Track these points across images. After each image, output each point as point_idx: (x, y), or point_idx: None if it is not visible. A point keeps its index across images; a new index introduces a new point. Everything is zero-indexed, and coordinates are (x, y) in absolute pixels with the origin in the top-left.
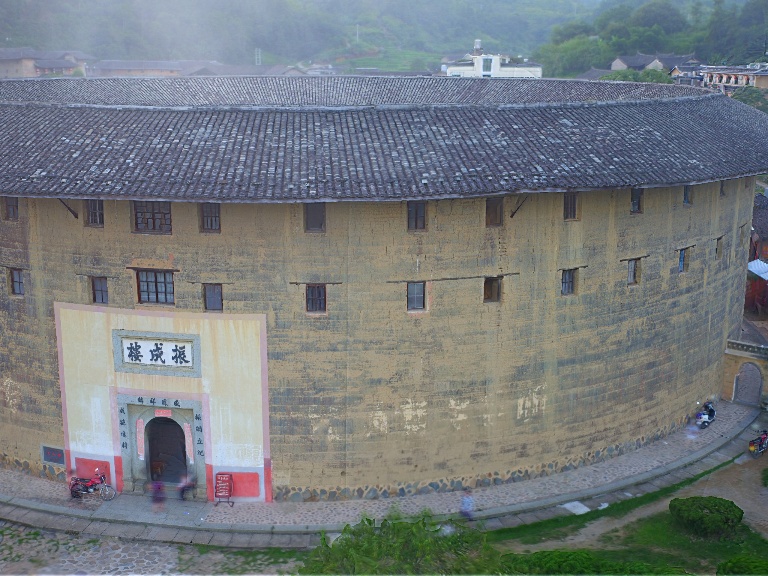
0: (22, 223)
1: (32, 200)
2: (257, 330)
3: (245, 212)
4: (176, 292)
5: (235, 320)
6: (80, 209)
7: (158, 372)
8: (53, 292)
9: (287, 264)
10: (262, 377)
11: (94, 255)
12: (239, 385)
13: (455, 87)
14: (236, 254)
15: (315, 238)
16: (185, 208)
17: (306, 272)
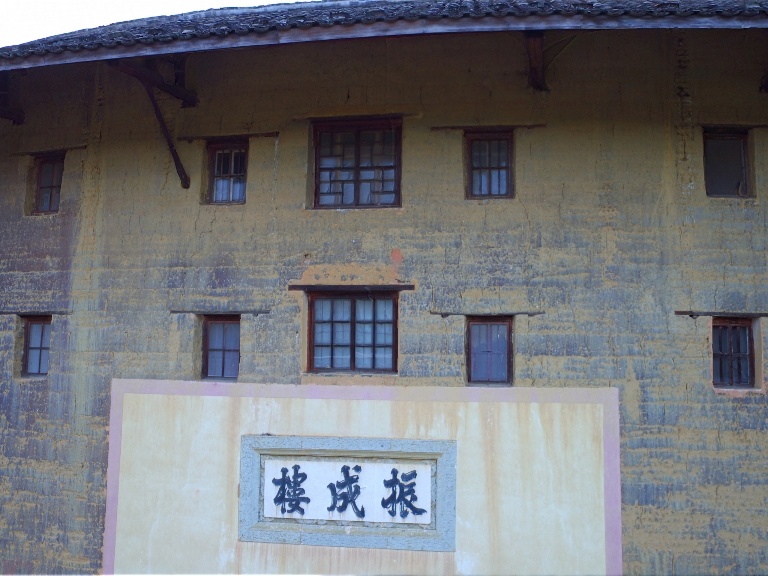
0: (65, 214)
1: (93, 163)
2: (596, 428)
3: (572, 150)
4: (402, 338)
5: (543, 403)
6: (195, 167)
7: (345, 539)
8: (113, 357)
9: (668, 267)
10: (607, 550)
11: (216, 264)
12: (549, 571)
13: None
14: (549, 244)
15: (731, 208)
16: (434, 146)
17: (712, 287)
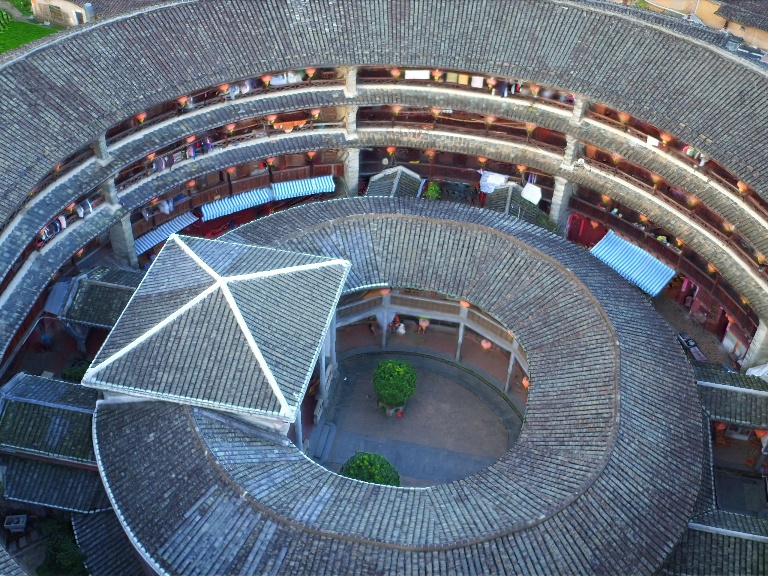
0: None
1: None
2: None
3: None
4: None
5: None
6: None
7: None
8: None
9: None
10: None
11: None
12: None
13: (8, 100)
14: None
15: None
16: None
17: None
